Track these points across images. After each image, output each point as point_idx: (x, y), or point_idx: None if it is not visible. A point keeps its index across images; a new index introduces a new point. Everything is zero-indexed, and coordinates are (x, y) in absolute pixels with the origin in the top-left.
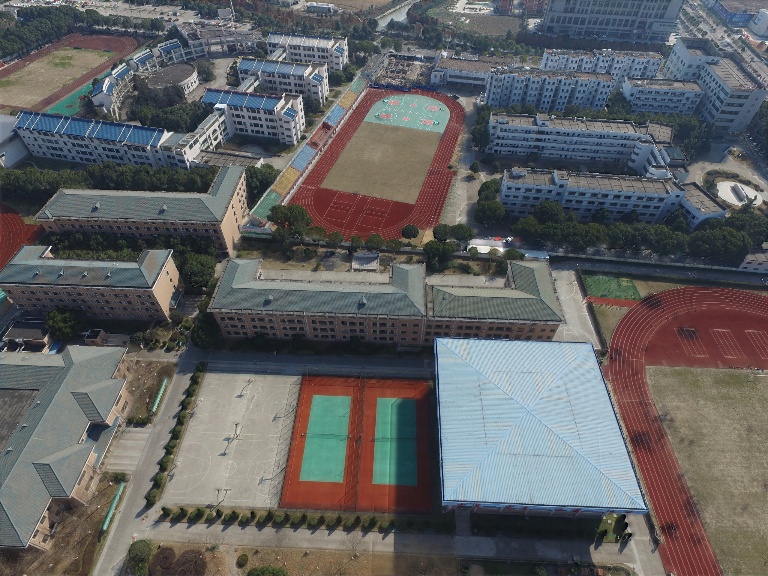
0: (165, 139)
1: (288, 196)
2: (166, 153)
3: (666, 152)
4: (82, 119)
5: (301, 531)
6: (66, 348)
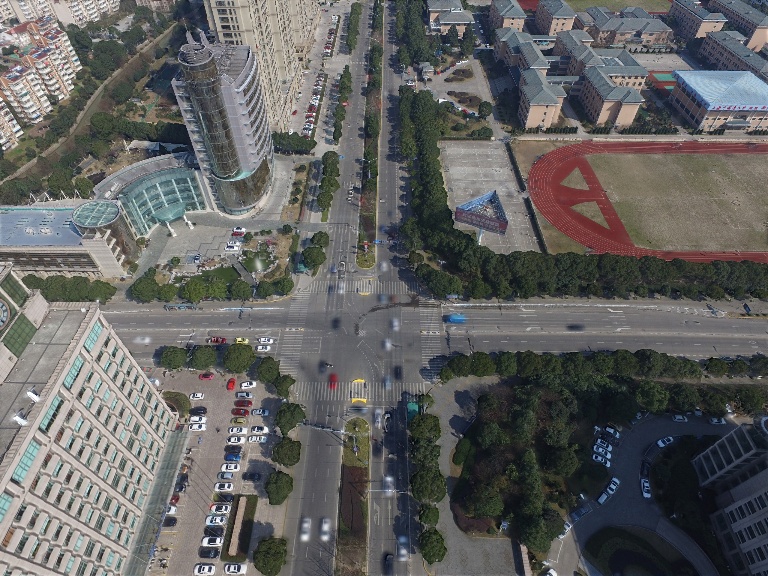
0: None
1: None
2: None
3: None
4: None
5: None
6: None
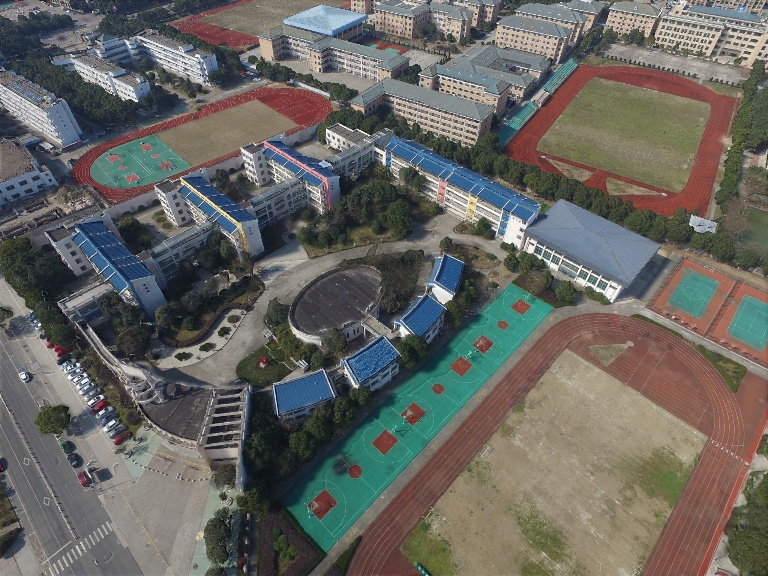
0: None
1: None
2: None
3: (109, 40)
4: (466, 174)
5: None
6: None
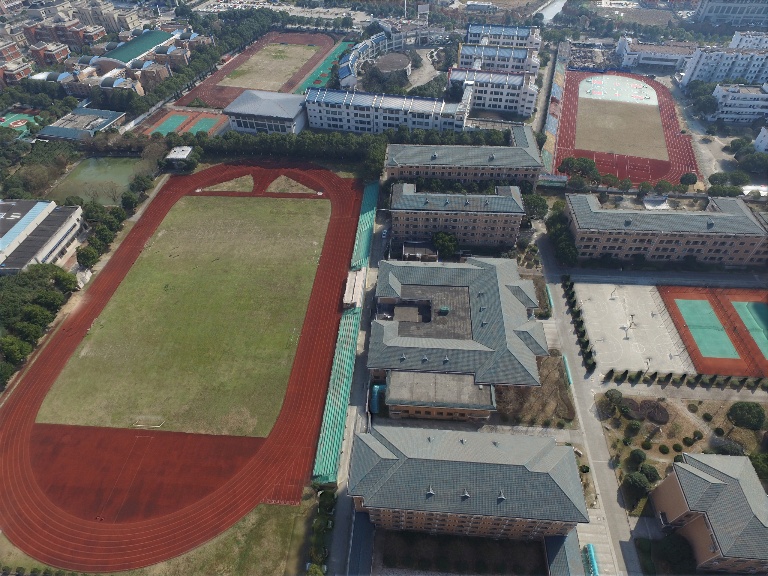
0: (442, 108)
1: None
2: (444, 120)
3: None
4: (365, 93)
5: (728, 390)
6: (468, 258)
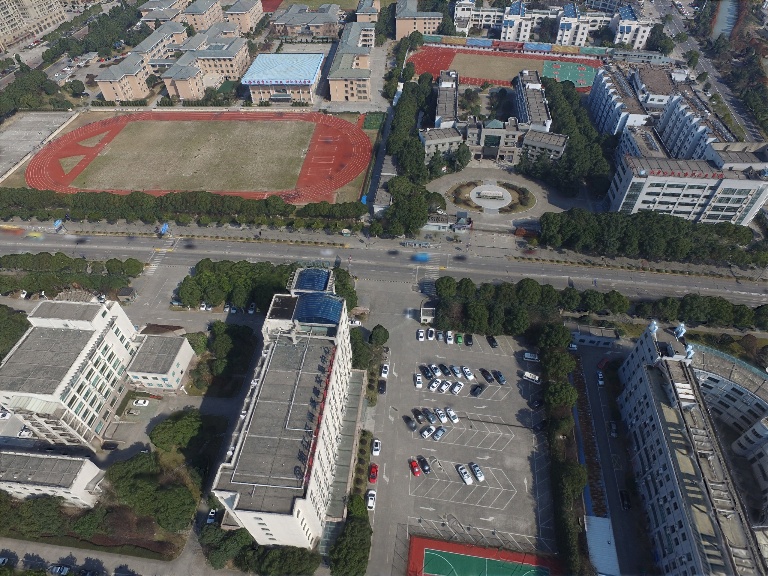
0: (466, 3)
1: (445, 46)
2: None
3: None
4: None
5: None
6: None
